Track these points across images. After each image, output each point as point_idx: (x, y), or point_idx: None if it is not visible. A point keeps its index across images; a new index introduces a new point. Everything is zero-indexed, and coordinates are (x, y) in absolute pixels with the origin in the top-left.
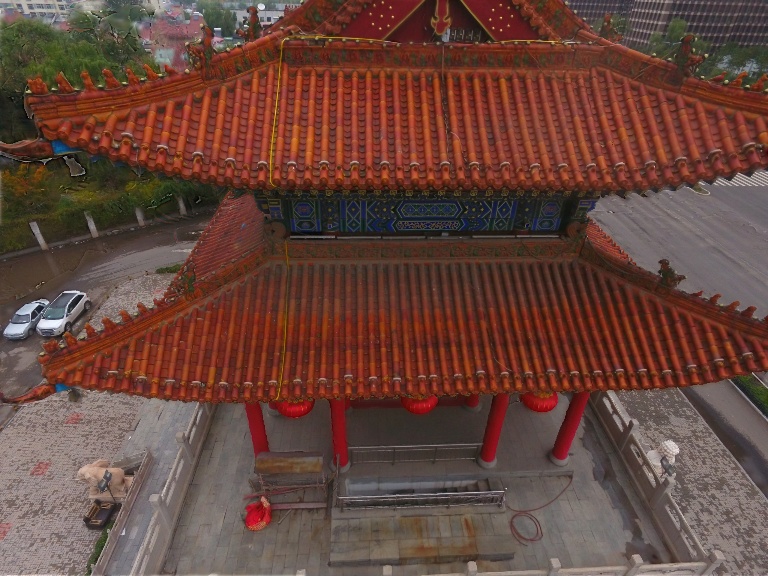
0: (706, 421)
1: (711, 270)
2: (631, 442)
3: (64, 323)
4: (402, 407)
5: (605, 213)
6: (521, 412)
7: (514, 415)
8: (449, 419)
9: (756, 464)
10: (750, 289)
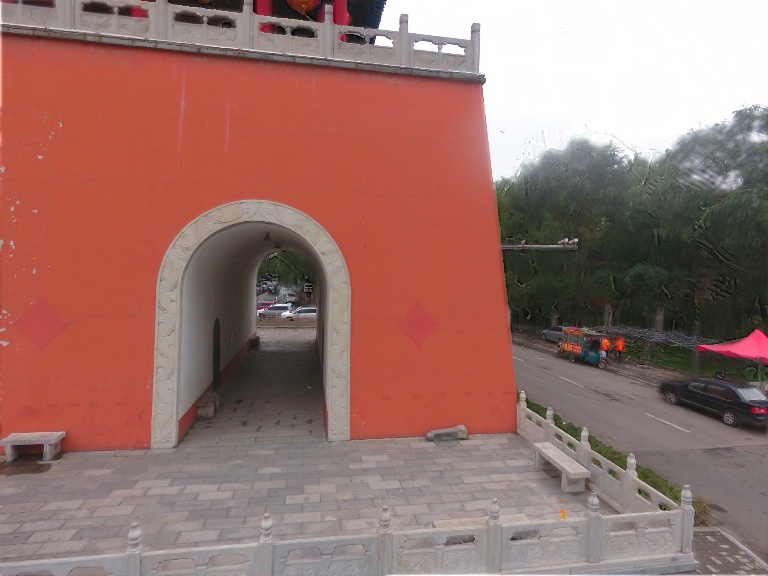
0: None
1: None
2: None
3: (288, 316)
4: None
5: None
6: None
7: None
8: None
9: None
10: None
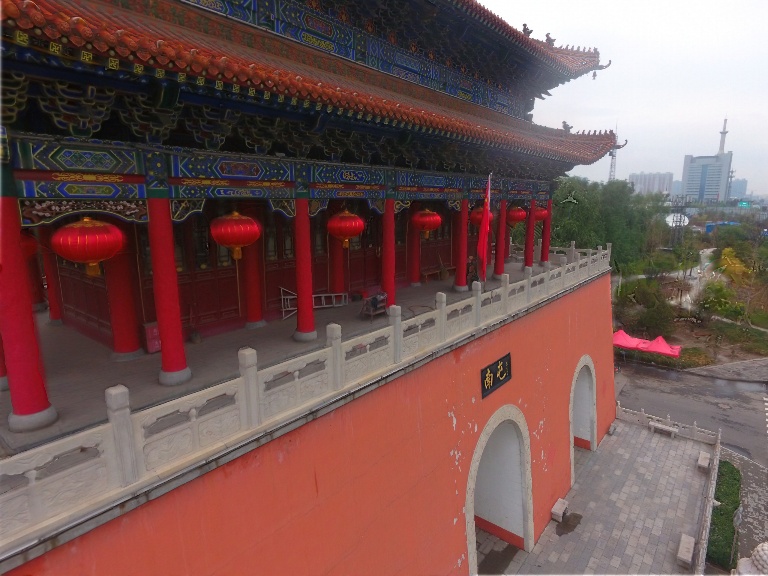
0: None
1: None
2: None
3: None
4: (85, 335)
5: None
6: (141, 379)
7: (128, 377)
8: (81, 353)
9: None
10: None
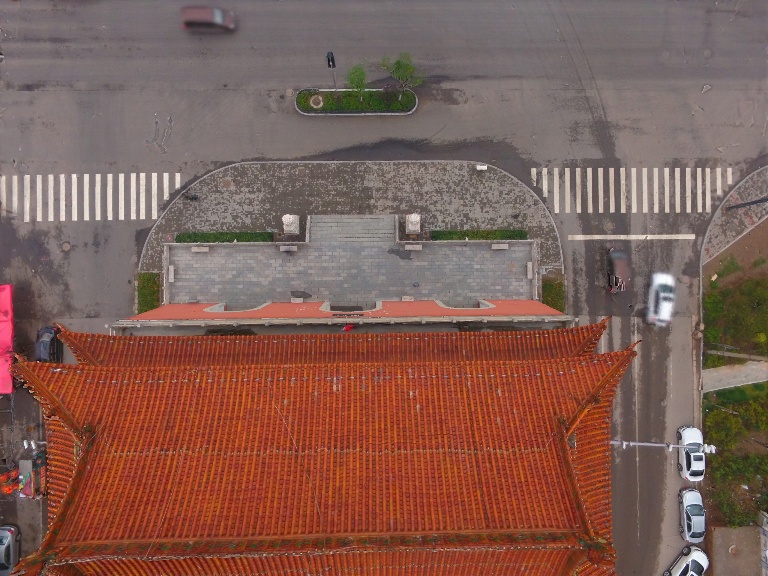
0: (370, 160)
1: (160, 17)
2: (517, 321)
3: None
4: None
5: (3, 68)
6: None
7: None
8: None
9: (404, 149)
10: (200, 0)
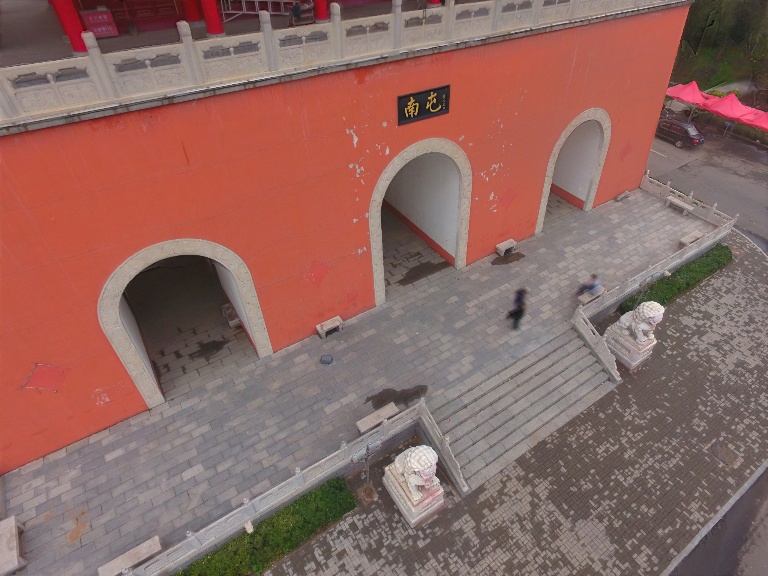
0: None
1: None
2: None
3: None
4: None
5: None
6: None
7: (61, 54)
8: (48, 34)
9: None
10: None
